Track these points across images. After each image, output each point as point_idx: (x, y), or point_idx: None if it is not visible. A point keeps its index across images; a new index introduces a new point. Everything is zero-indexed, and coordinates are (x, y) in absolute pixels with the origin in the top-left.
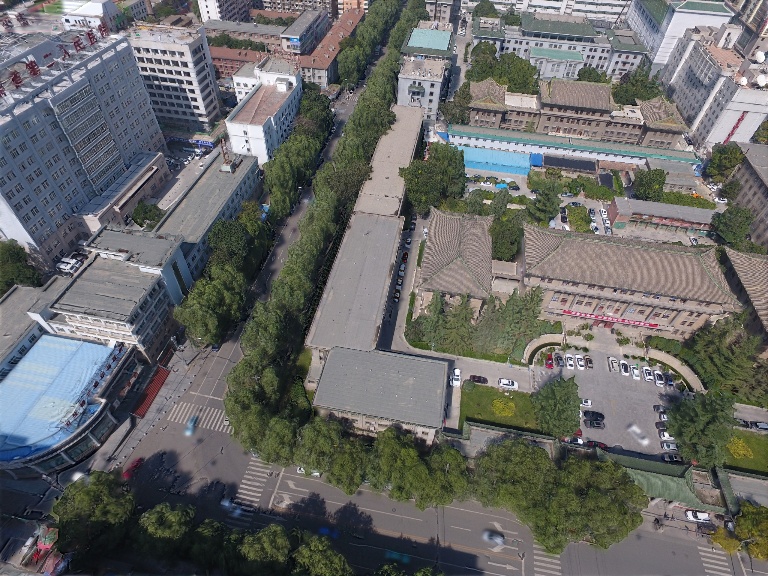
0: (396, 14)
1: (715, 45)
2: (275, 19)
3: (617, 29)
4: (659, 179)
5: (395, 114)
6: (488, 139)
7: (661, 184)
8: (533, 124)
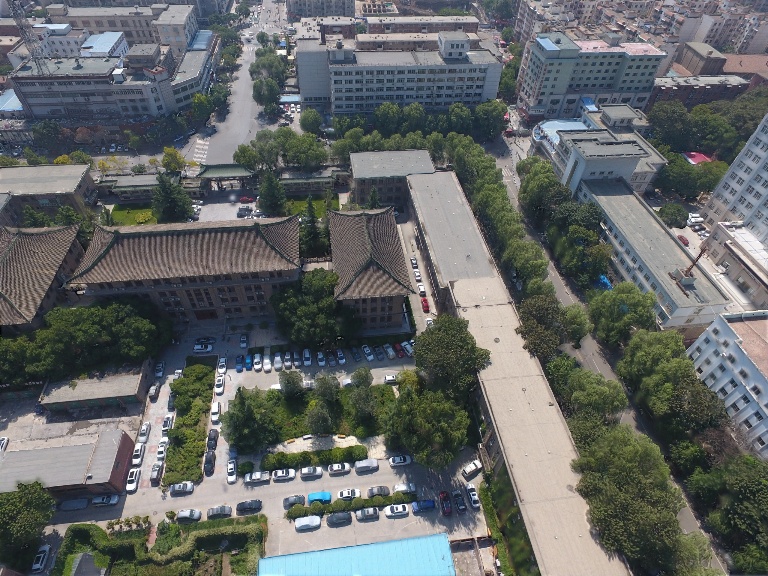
0: None
1: None
2: None
3: None
4: None
5: None
6: None
7: None
8: None
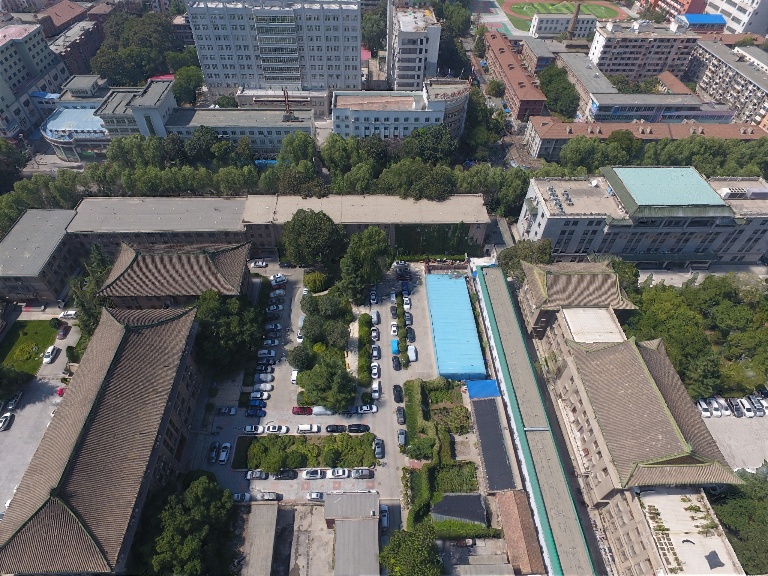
0: None
1: None
2: None
3: None
4: None
5: None
6: None
7: None
8: None
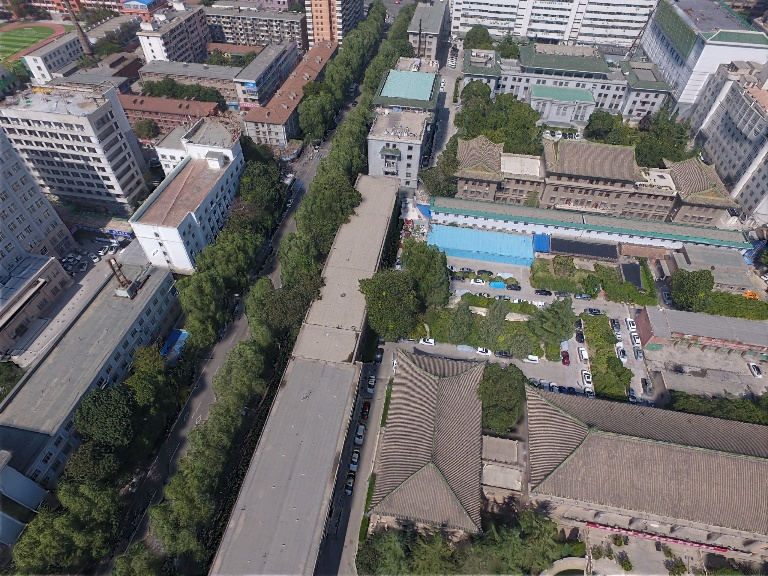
0: (375, 45)
1: (758, 87)
2: (231, 57)
3: (633, 61)
4: (705, 285)
5: (361, 192)
6: (480, 217)
7: (708, 290)
8: (536, 193)
